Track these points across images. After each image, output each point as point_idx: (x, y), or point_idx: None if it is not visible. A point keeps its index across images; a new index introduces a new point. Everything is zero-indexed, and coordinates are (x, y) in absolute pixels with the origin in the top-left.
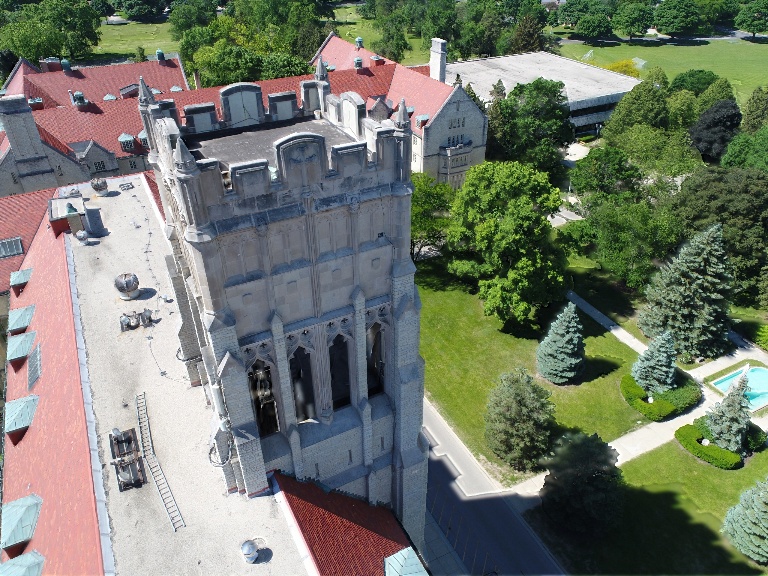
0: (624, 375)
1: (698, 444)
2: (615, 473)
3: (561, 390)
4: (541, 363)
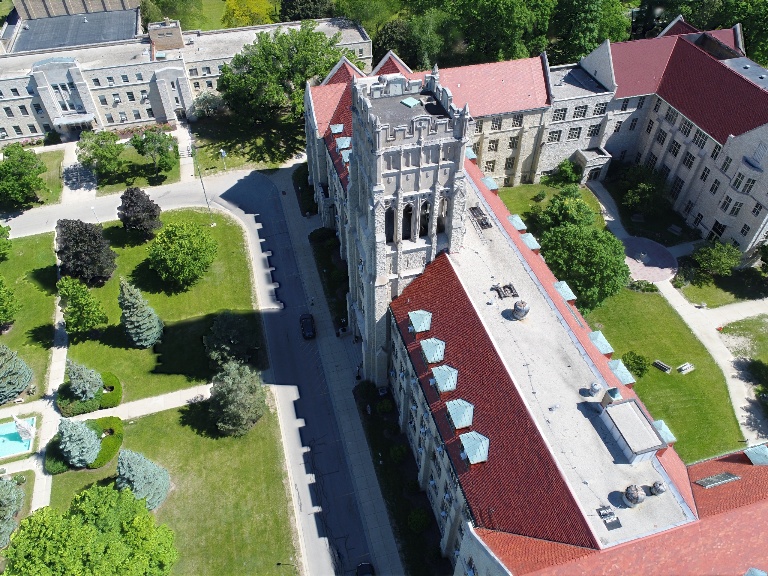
0: (94, 474)
1: (115, 387)
2: (223, 312)
3: (165, 465)
4: (165, 484)
